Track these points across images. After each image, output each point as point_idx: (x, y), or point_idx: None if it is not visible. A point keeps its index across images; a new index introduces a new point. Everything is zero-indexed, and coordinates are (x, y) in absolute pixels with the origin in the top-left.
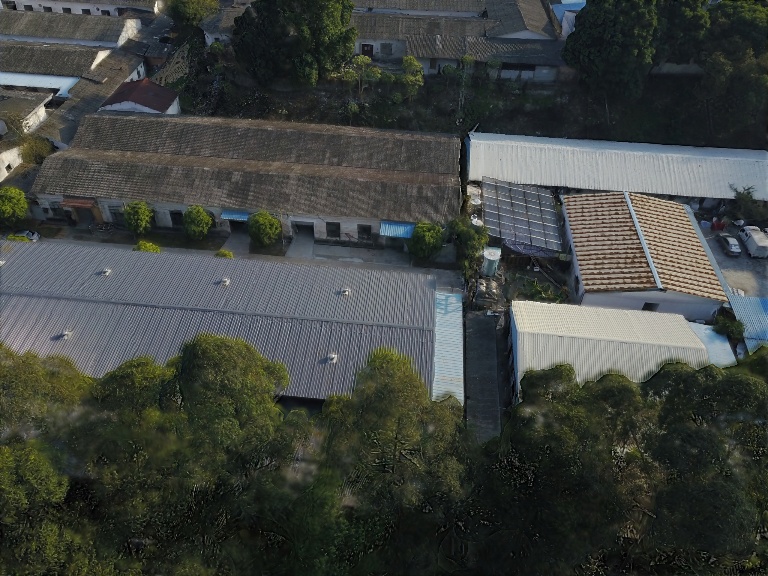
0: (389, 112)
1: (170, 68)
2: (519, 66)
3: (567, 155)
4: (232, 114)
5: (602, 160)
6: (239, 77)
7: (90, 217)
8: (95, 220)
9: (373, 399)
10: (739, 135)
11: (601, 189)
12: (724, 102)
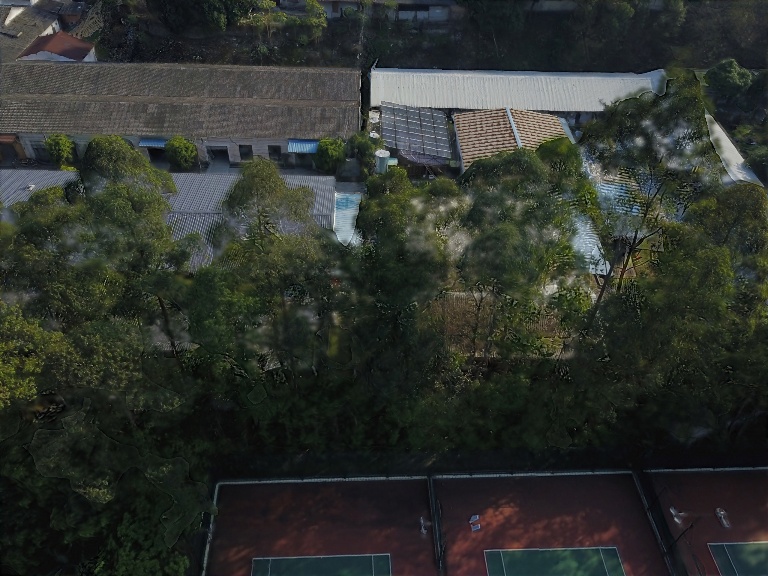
0: (297, 54)
1: (85, 24)
2: (414, 7)
3: (458, 81)
4: (148, 62)
5: (489, 84)
6: (152, 27)
7: (13, 155)
8: (18, 156)
9: (240, 186)
10: (611, 61)
11: (488, 109)
12: (598, 33)
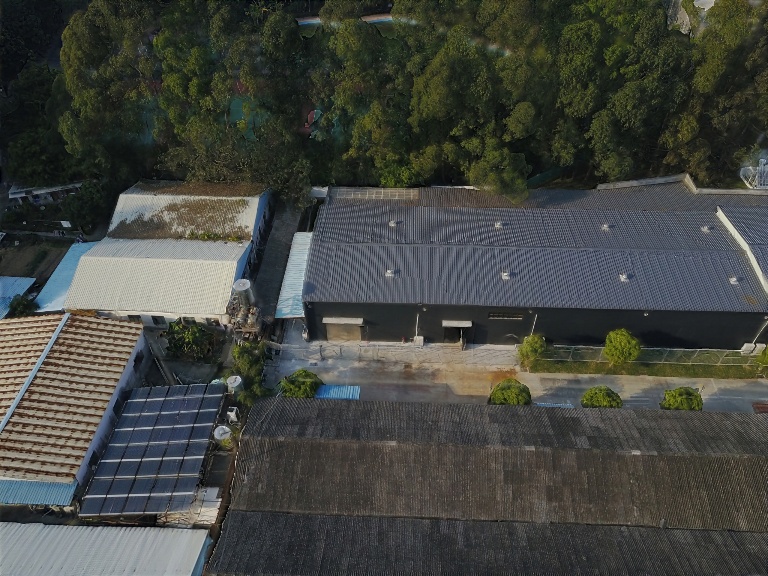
0: None
1: None
2: None
3: None
4: None
5: None
6: None
7: None
8: None
9: (355, 2)
10: None
11: None
12: None
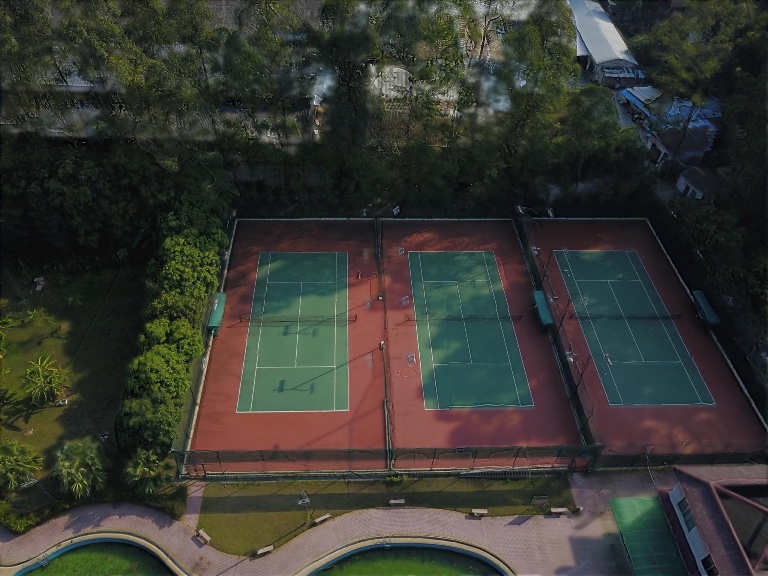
0: None
1: None
2: None
3: None
4: None
5: None
6: None
7: None
8: None
9: None
10: None
11: None
12: None
